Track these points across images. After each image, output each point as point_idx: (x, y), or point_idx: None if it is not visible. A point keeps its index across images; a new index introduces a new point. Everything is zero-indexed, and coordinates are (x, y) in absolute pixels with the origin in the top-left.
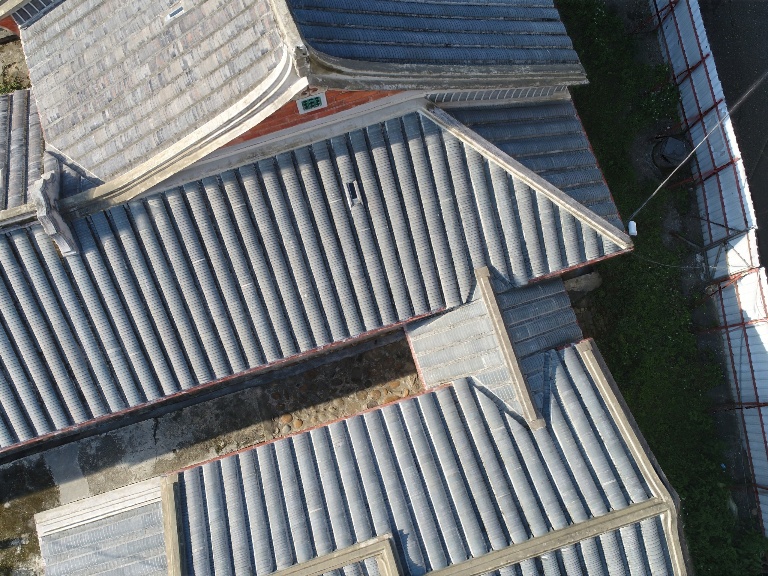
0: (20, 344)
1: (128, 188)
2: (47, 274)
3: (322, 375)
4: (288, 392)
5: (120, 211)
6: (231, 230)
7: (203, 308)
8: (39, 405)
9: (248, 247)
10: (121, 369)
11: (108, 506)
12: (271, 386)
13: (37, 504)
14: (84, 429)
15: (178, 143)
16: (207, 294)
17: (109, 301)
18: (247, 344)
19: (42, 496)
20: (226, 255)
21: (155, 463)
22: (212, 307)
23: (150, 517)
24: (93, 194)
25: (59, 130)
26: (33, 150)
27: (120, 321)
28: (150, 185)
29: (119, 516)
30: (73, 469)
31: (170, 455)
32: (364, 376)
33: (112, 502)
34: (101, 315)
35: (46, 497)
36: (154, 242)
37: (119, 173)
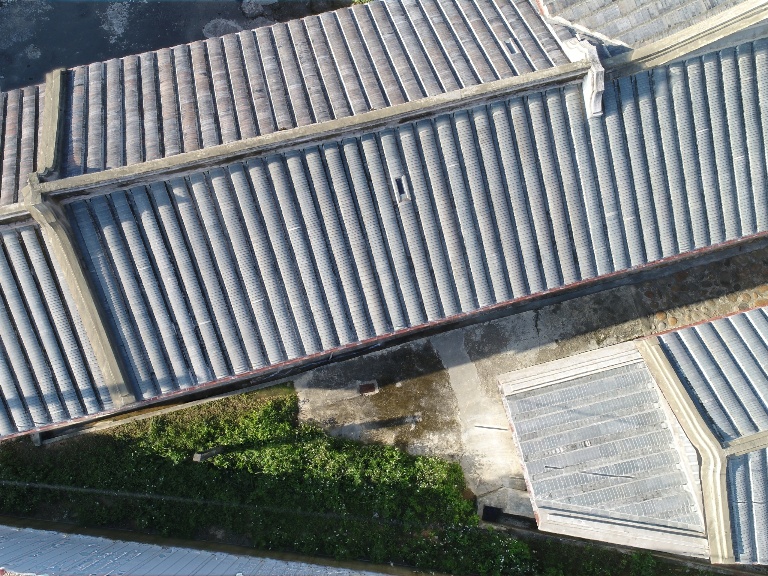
0: (534, 201)
1: (666, 52)
2: (568, 135)
3: (692, 277)
4: (661, 291)
5: (645, 76)
6: (736, 102)
7: (697, 177)
8: (538, 263)
9: (748, 120)
10: (616, 232)
11: (580, 367)
12: (644, 285)
13: (428, 385)
14: (468, 317)
15: (742, 5)
16: (704, 164)
17: (619, 165)
18: (729, 216)
19: (432, 378)
20: (725, 127)
21: (539, 351)
22: (706, 177)
23: (624, 378)
24: (631, 57)
25: (568, 3)
26: (534, 23)
27: (624, 185)
28: (692, 49)
29: (588, 378)
30: (460, 354)
31: (553, 345)
32: (733, 279)
33: (582, 364)
34: (609, 178)
35: (436, 379)
36: (668, 109)
37: (650, 39)
